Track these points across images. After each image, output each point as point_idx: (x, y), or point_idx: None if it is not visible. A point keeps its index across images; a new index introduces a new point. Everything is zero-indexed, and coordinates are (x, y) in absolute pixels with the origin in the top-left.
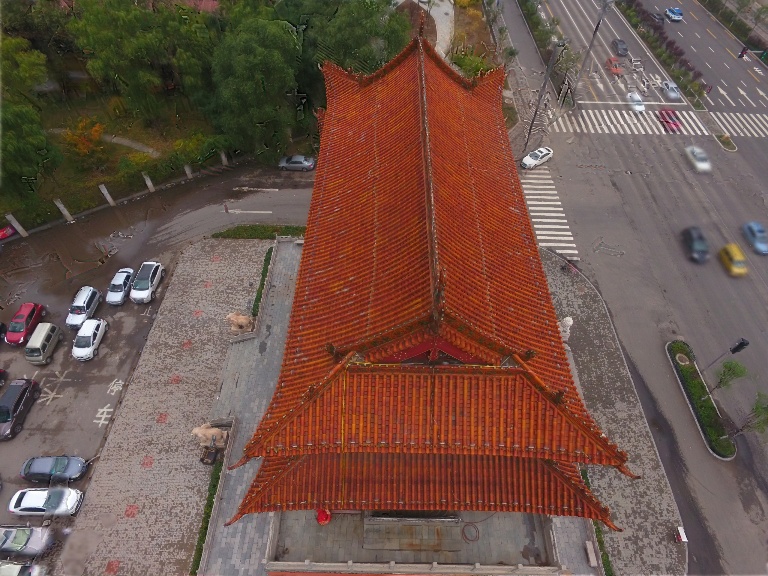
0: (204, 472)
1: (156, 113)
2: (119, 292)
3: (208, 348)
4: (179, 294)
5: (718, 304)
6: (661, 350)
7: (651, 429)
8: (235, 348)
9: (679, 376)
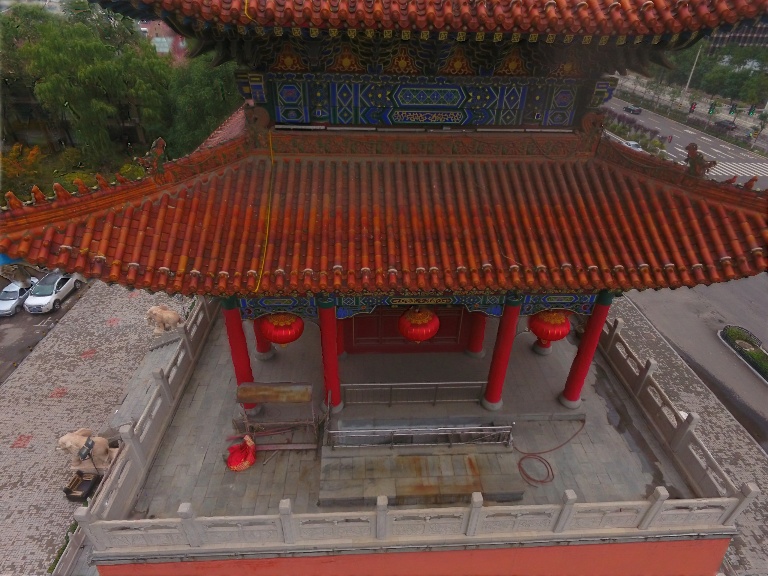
0: (67, 513)
1: (108, 151)
2: (11, 300)
3: (117, 356)
4: (93, 304)
5: (759, 295)
6: (714, 338)
7: (741, 422)
8: (155, 353)
9: (749, 362)
